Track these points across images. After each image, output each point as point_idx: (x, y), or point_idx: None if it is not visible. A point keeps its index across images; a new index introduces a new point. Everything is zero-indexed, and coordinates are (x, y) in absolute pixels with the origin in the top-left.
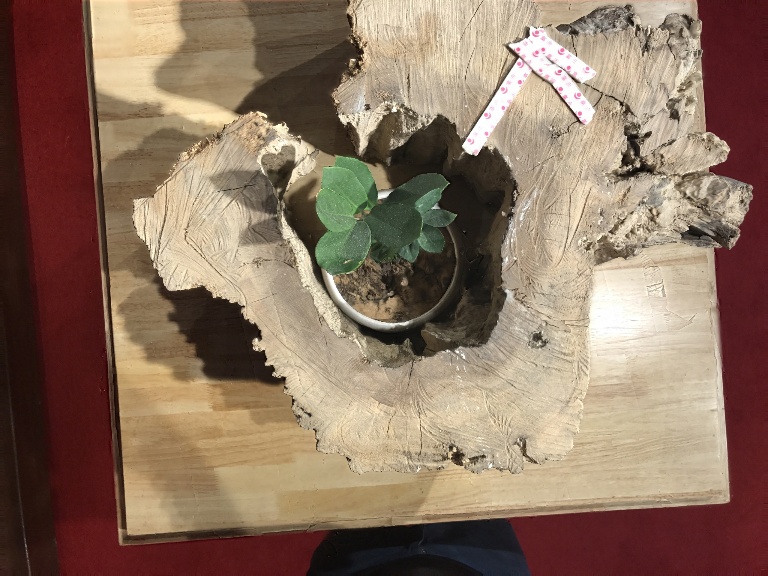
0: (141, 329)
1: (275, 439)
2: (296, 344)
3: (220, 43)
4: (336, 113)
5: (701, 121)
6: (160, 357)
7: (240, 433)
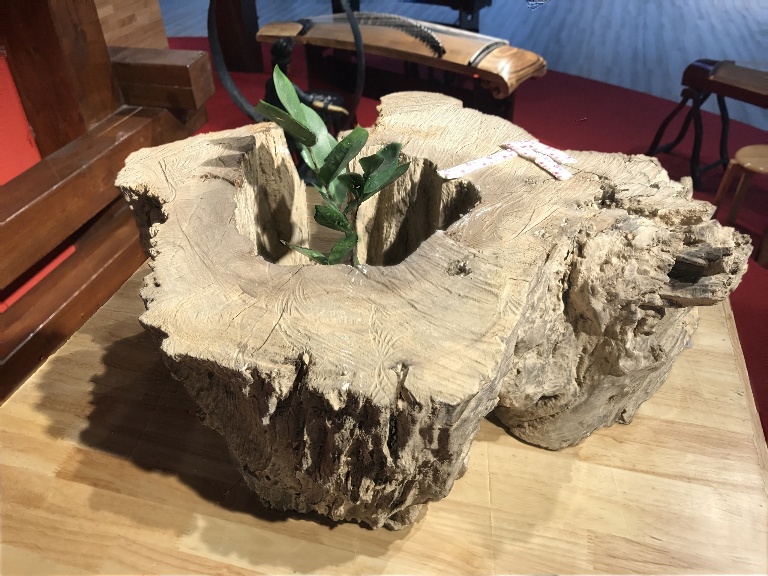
0: (57, 380)
1: (97, 533)
2: (193, 230)
3: None
4: None
5: (743, 374)
6: (51, 408)
7: (62, 511)
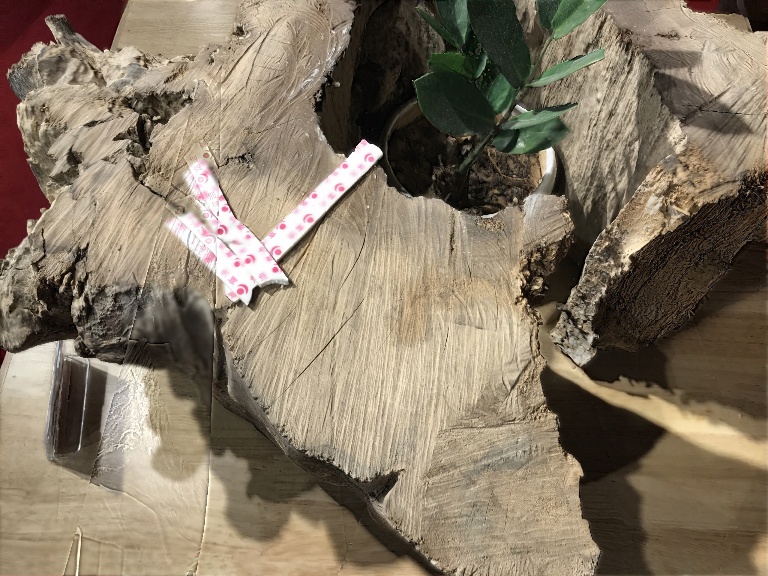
0: None
1: None
2: None
3: (698, 540)
4: None
5: None
6: None
7: None
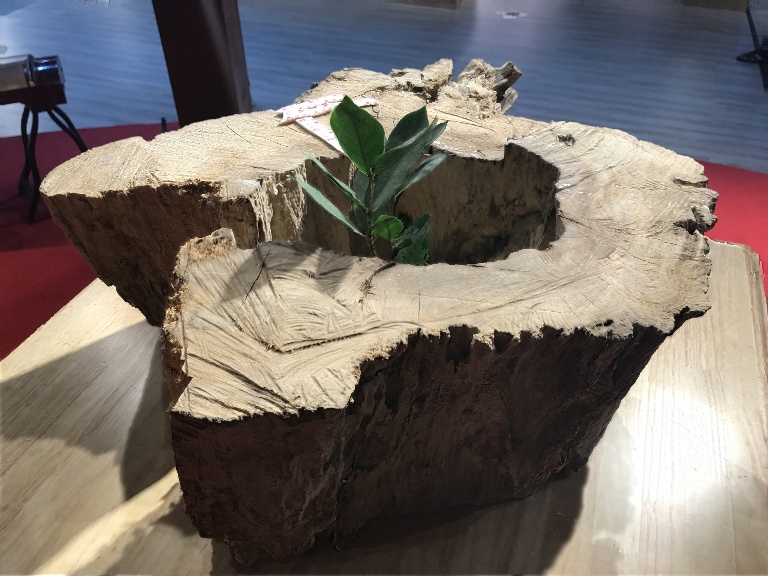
0: None
1: None
2: (499, 296)
3: (34, 483)
4: (245, 201)
5: None
6: None
7: None
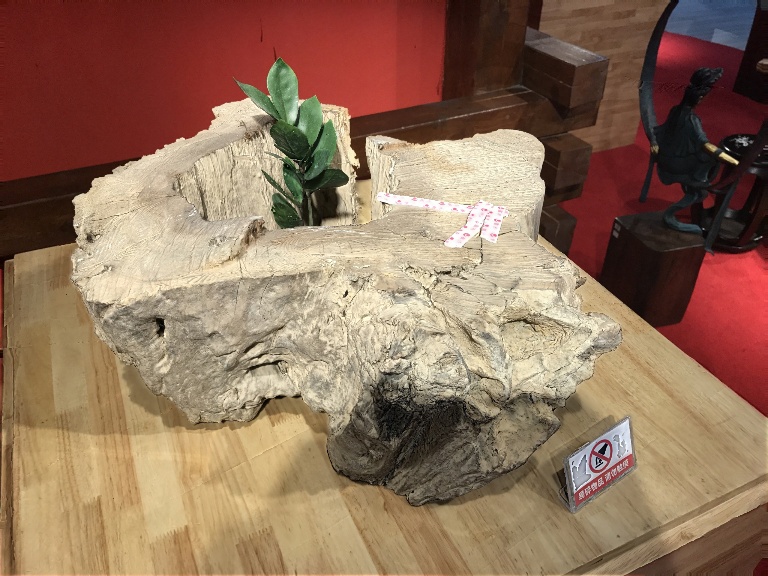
0: None
1: None
2: None
3: None
4: None
5: None
6: None
7: None
